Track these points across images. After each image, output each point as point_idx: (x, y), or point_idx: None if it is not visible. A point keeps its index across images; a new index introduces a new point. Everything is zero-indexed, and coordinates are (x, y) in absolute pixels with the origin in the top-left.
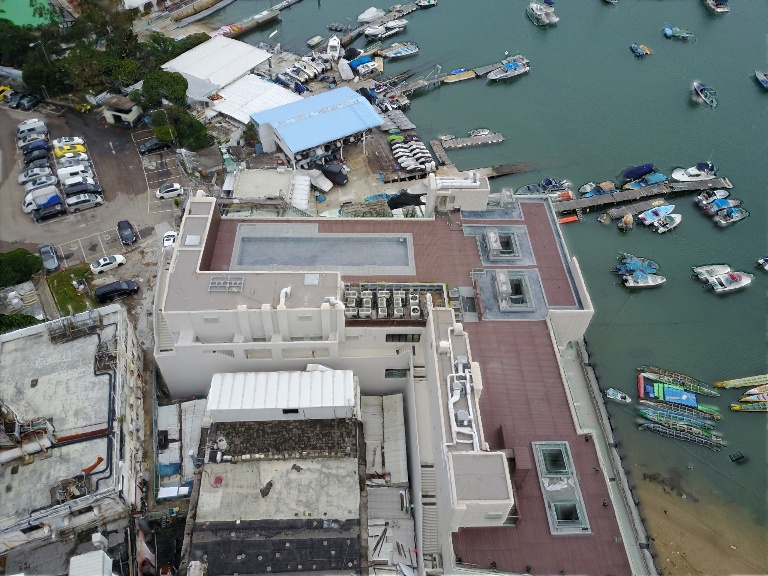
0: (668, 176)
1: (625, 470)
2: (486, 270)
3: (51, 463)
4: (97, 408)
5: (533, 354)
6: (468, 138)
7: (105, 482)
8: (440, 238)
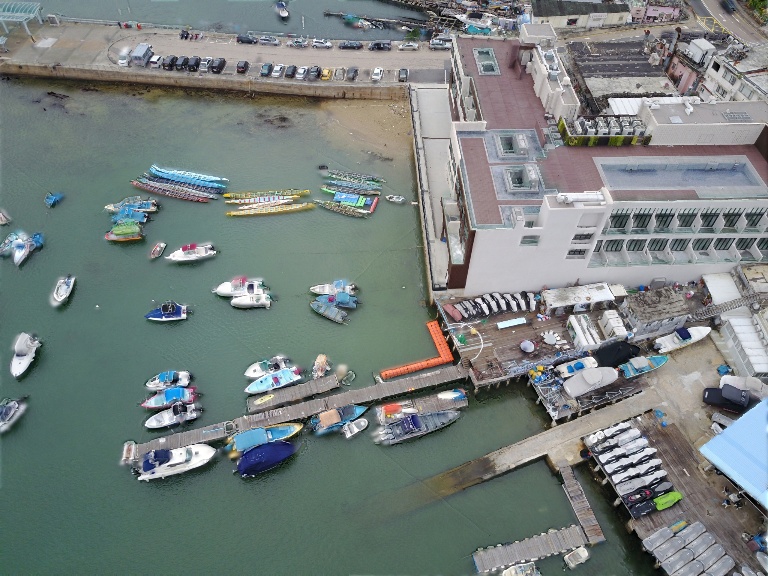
0: (223, 449)
1: (404, 163)
2: (534, 161)
3: (759, 64)
4: (759, 82)
5: (496, 111)
6: (540, 552)
7: (724, 59)
8: (579, 186)
